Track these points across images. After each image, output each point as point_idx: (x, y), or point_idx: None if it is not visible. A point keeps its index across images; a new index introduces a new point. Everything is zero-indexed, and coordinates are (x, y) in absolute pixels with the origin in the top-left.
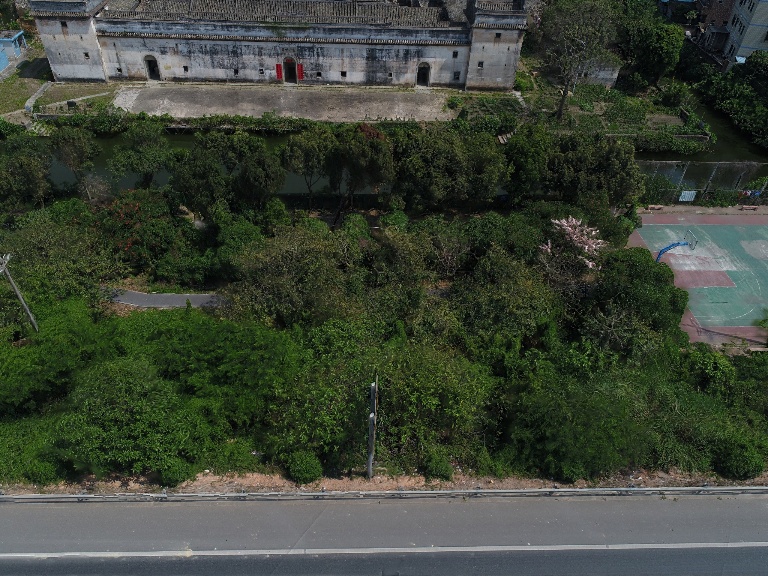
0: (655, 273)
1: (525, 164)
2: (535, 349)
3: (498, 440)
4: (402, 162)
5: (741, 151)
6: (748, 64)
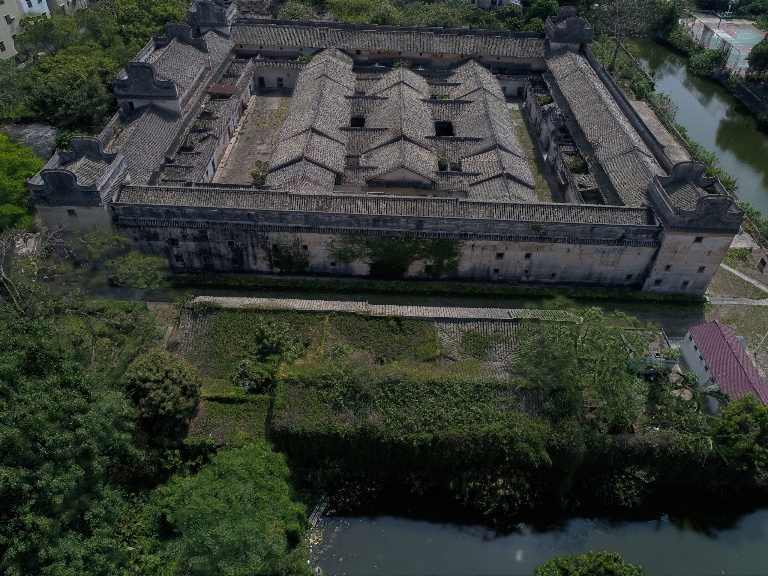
0: None
1: None
2: None
3: None
4: None
5: None
6: None
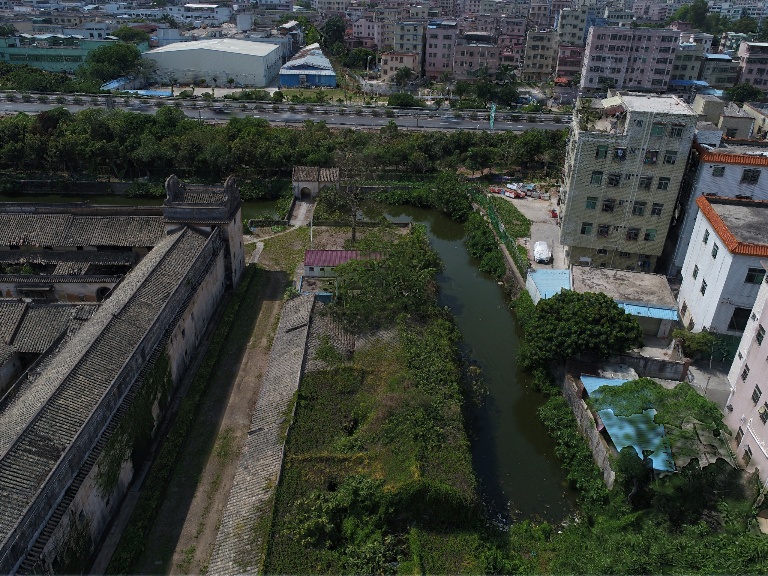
0: None
1: None
2: None
3: None
4: None
5: None
6: None
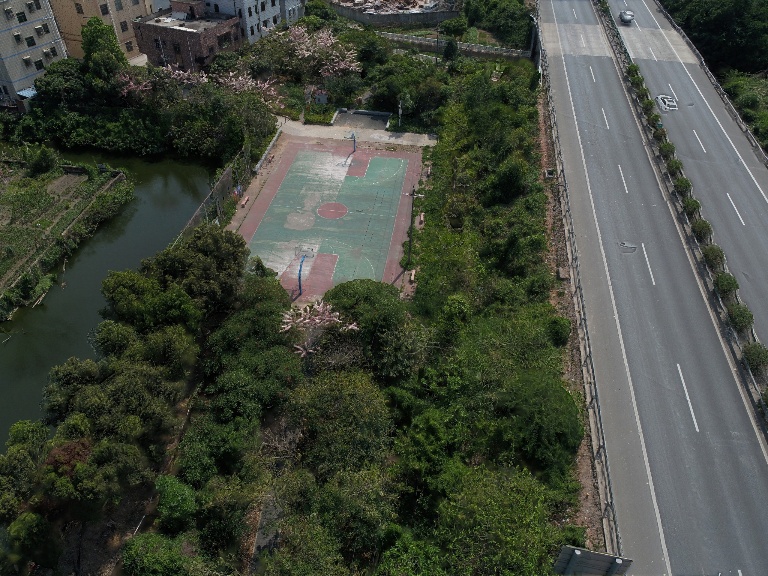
0: (375, 290)
1: (183, 315)
2: (438, 412)
3: (537, 477)
4: (105, 440)
5: (146, 167)
6: (44, 95)
